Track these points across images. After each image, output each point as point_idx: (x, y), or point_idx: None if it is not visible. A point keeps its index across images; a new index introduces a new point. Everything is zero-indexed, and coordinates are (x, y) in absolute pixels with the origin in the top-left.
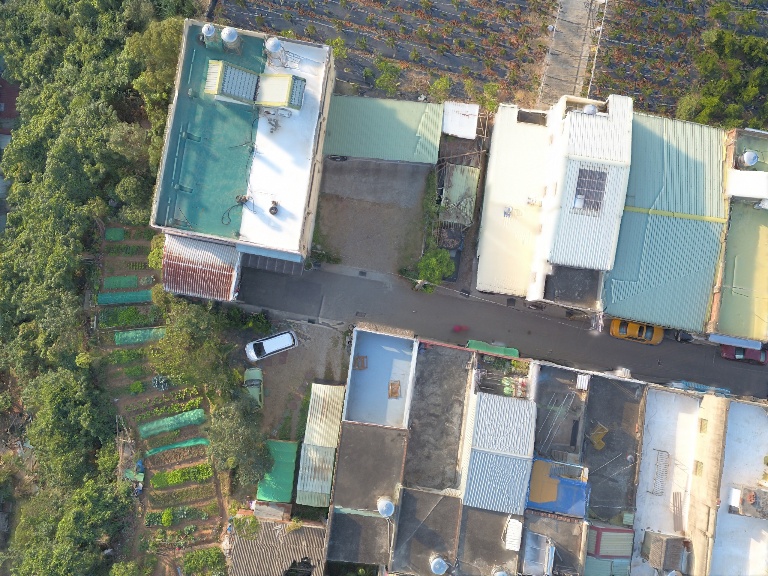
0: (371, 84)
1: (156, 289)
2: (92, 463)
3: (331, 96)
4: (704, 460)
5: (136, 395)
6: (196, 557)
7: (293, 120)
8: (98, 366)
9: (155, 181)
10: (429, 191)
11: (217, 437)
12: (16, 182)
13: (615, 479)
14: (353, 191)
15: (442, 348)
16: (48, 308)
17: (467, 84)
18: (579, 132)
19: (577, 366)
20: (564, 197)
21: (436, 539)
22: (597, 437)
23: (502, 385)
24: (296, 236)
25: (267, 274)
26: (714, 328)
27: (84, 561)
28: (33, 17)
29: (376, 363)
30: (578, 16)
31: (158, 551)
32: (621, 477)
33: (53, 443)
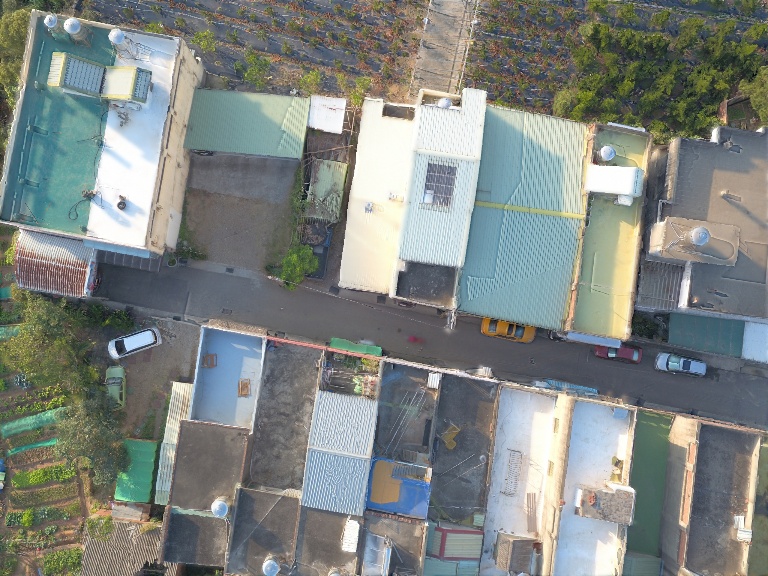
0: (242, 78)
1: (14, 285)
2: None
3: (195, 89)
4: (554, 460)
5: None
6: (56, 558)
7: (144, 113)
8: None
9: None
10: (295, 186)
11: (64, 436)
12: None
13: (468, 479)
14: (221, 186)
15: (293, 346)
16: None
17: (339, 78)
18: (429, 126)
19: (447, 364)
20: (413, 192)
21: (274, 540)
22: (449, 437)
23: (353, 383)
24: (144, 231)
25: (132, 270)
26: (571, 326)
27: None
28: None
29: (226, 361)
30: (454, 9)
31: (18, 551)
32: (474, 477)
33: None
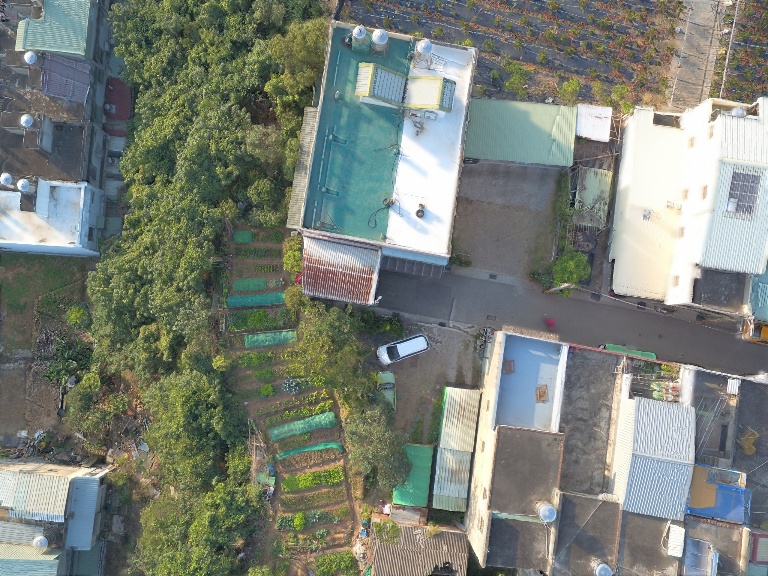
0: (498, 86)
1: (291, 292)
2: (219, 466)
3: None
4: None
5: (266, 398)
6: (329, 561)
7: (438, 123)
8: (229, 369)
9: (284, 183)
10: (562, 194)
11: (363, 441)
12: (137, 184)
13: (764, 484)
14: (483, 194)
15: (589, 352)
16: (183, 311)
17: (596, 86)
18: (731, 135)
19: None
20: (717, 200)
21: (596, 545)
22: (747, 442)
23: (651, 389)
24: (443, 239)
25: (397, 277)
26: None
27: (222, 565)
28: (155, 19)
29: (523, 367)
30: (705, 18)
31: None
32: None
33: (181, 446)
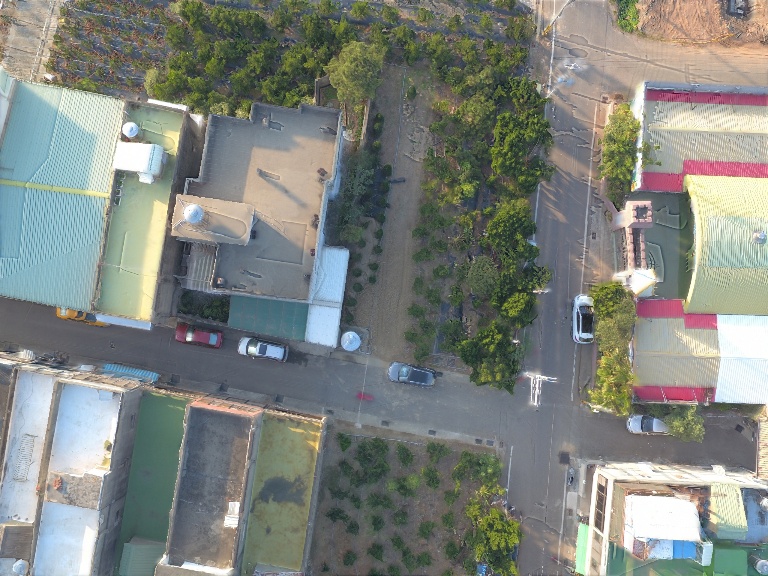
0: None
1: None
2: None
3: None
4: None
5: None
6: None
7: None
8: None
9: None
10: None
11: None
12: None
13: None
14: None
15: None
16: None
17: None
18: None
19: (20, 348)
20: None
21: None
22: None
23: None
24: None
25: None
26: None
27: None
28: None
29: None
30: None
31: None
32: None
33: None
